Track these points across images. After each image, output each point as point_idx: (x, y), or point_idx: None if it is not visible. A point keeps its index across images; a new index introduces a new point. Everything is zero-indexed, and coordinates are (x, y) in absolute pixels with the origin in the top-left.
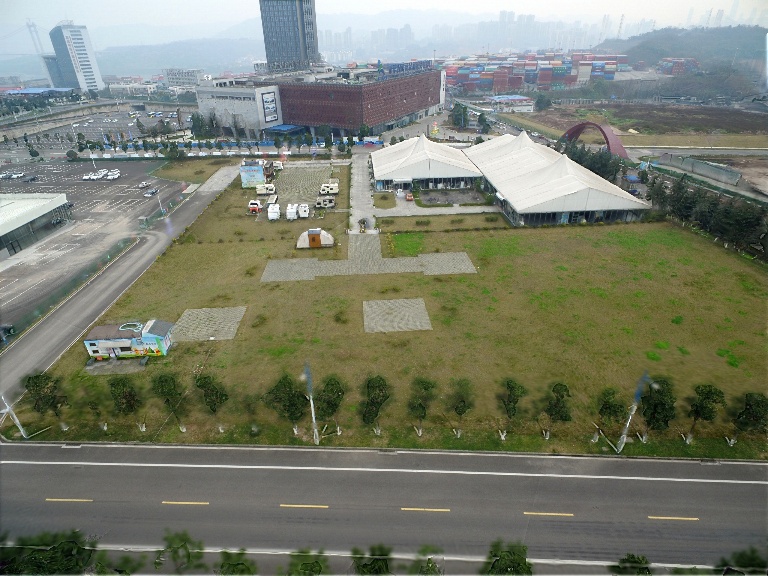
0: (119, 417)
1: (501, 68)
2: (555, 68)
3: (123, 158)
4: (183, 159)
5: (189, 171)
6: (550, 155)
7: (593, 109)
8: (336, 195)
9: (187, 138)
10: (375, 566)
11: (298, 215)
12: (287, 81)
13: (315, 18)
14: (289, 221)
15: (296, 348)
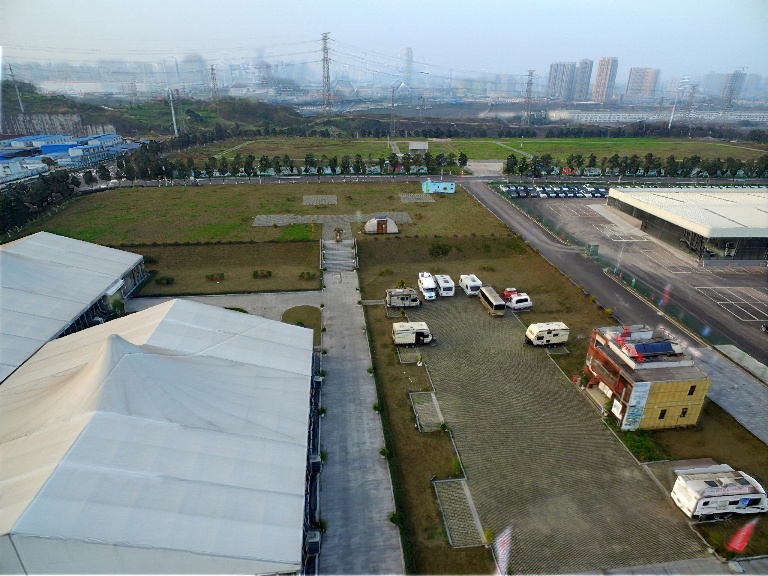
0: (418, 183)
1: None
2: None
3: None
4: None
5: None
6: None
7: None
8: None
9: None
10: (333, 159)
11: None
12: None
13: None
14: None
15: (367, 191)
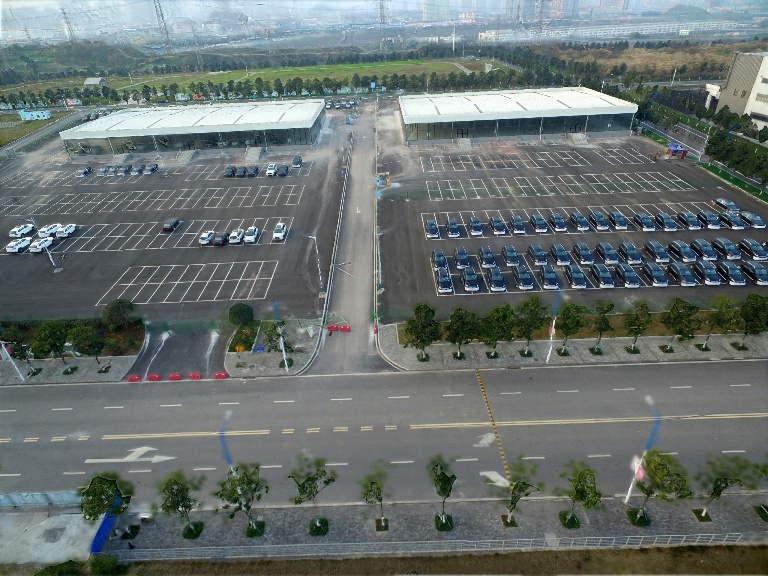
0: None
1: None
2: None
3: None
4: None
5: None
6: None
7: None
8: None
9: None
10: (1, 97)
11: None
12: None
13: None
14: None
15: None
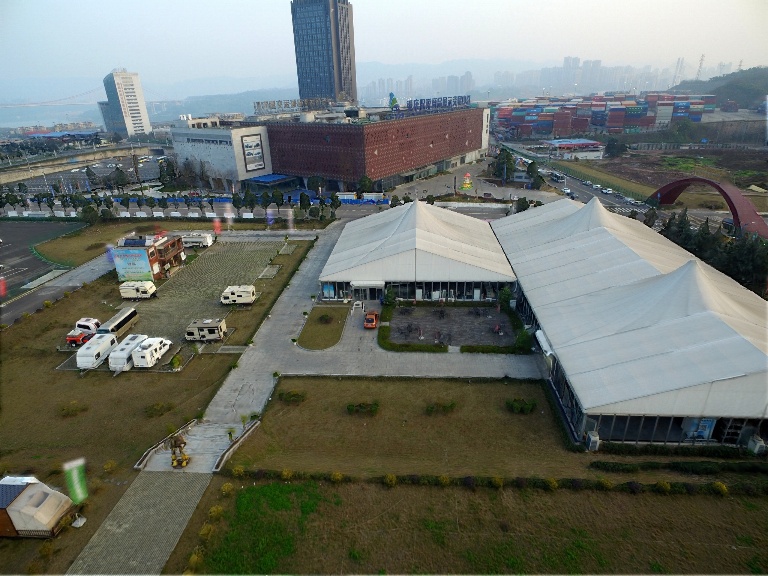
0: None
1: (563, 109)
2: (628, 108)
3: (39, 218)
4: (107, 221)
5: (88, 243)
6: (646, 243)
7: (685, 156)
8: (249, 306)
9: (157, 189)
10: None
11: (132, 363)
12: (285, 121)
13: (354, 58)
14: (113, 375)
15: None
